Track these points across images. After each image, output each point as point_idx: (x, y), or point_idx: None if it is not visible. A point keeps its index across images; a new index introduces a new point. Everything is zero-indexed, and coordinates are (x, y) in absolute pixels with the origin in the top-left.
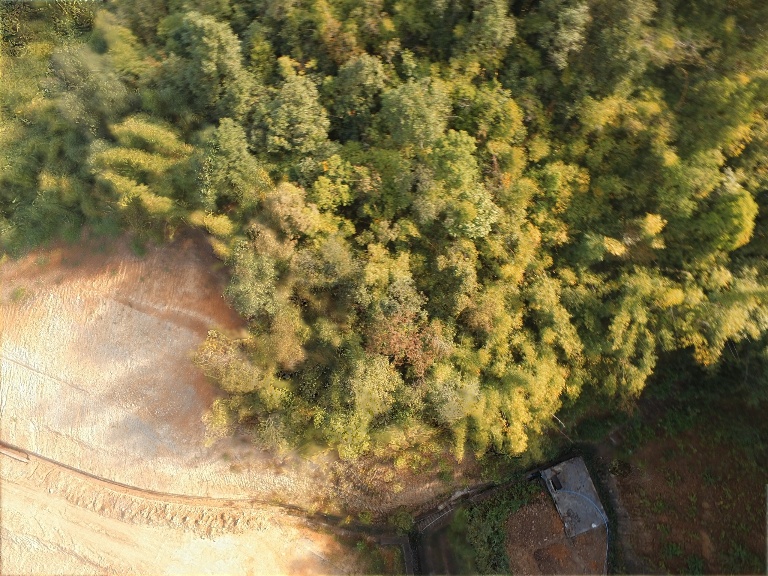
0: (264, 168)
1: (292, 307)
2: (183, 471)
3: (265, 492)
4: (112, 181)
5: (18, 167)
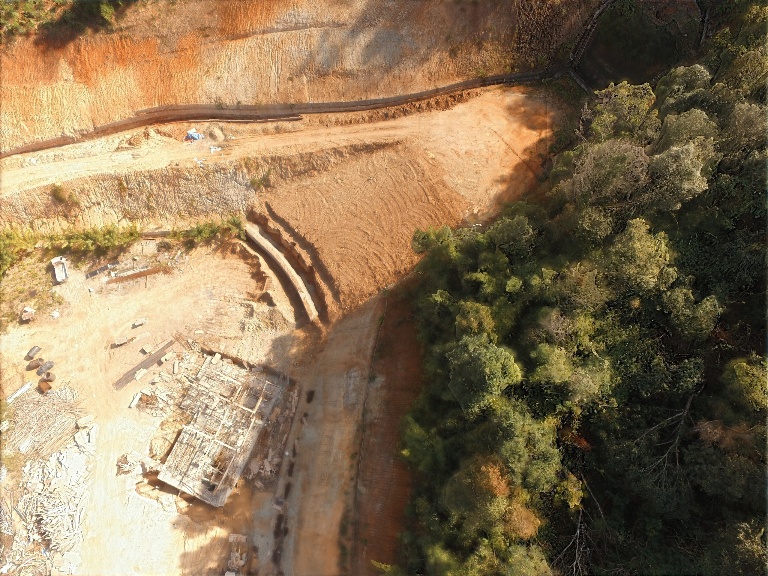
0: None
1: None
2: (419, 68)
3: (472, 74)
4: None
5: None
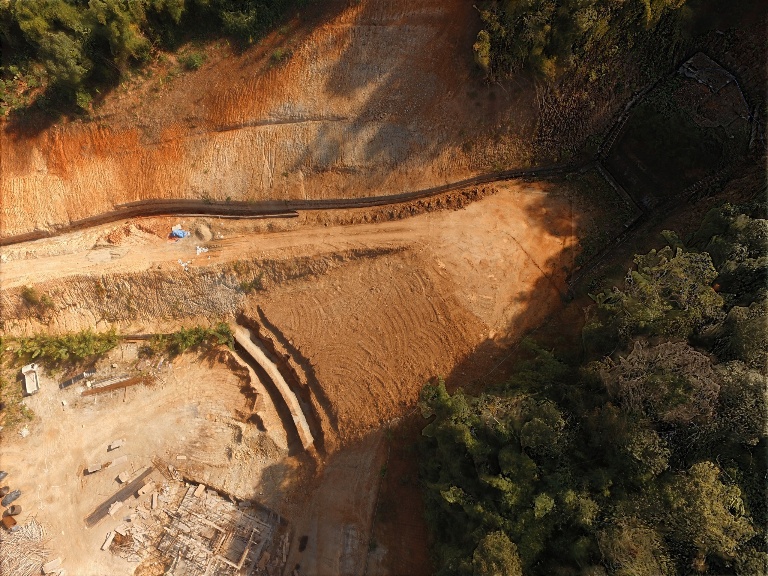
0: None
1: None
2: (428, 163)
3: (487, 167)
4: None
5: None
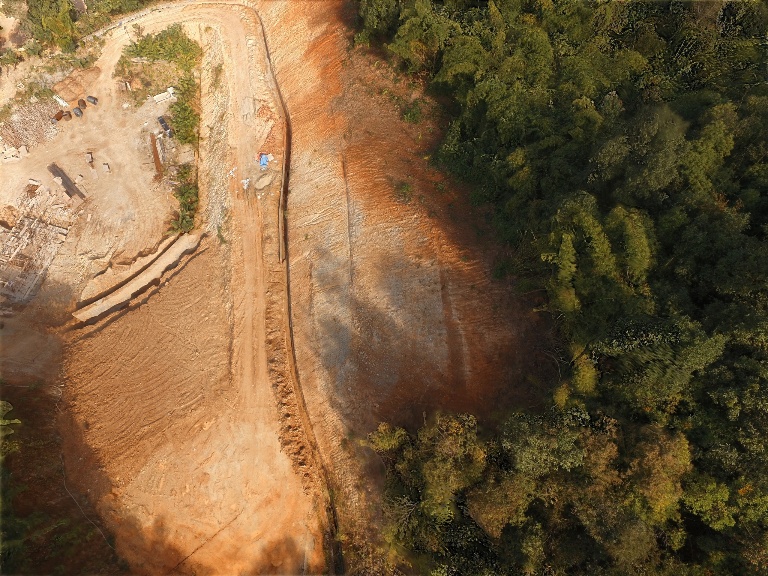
0: (684, 390)
1: (542, 487)
2: (324, 396)
3: (337, 478)
4: (563, 242)
5: (508, 126)
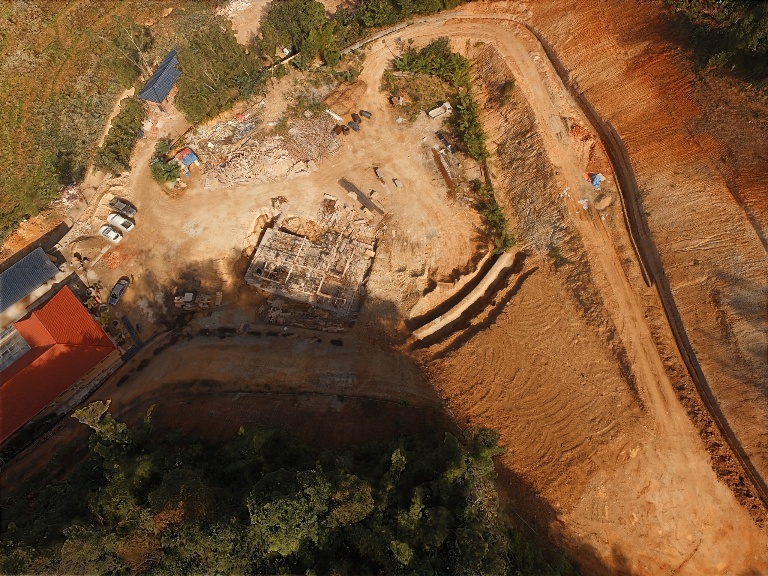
0: None
1: None
2: None
3: None
4: None
5: None
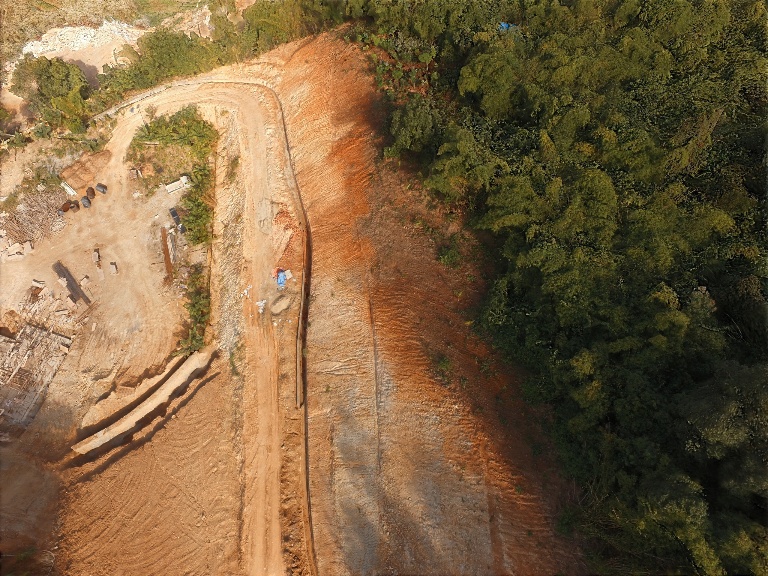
0: None
1: None
2: None
3: None
4: None
5: (569, 311)
